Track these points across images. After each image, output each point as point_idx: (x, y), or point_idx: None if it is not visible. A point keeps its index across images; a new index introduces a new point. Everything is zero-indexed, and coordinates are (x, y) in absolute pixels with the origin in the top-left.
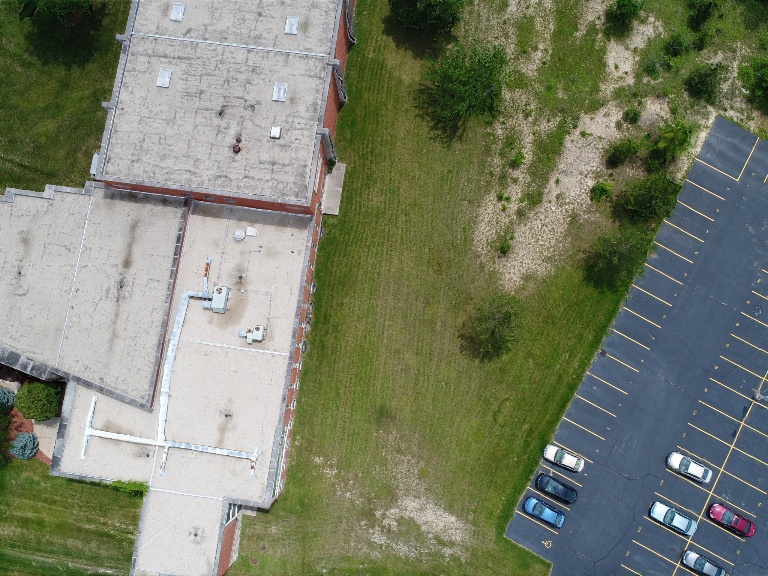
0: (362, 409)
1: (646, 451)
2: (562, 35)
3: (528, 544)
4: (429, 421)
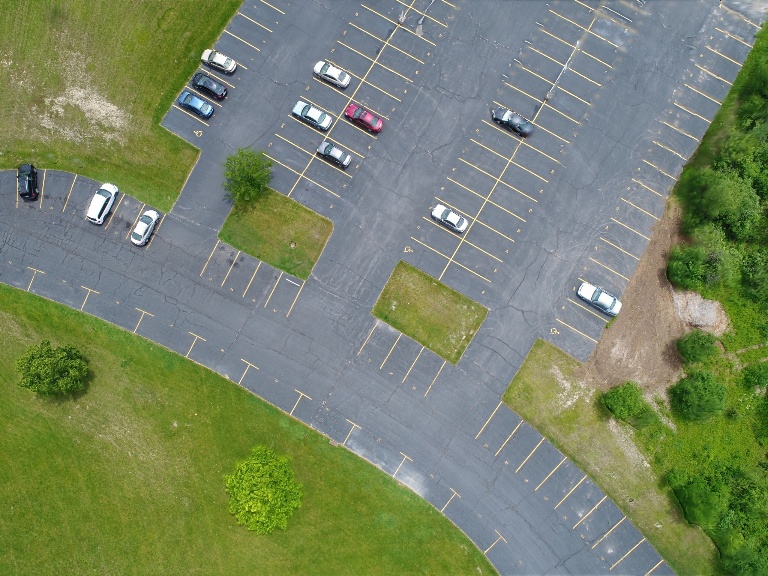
0: (38, 9)
1: (297, 62)
2: None
3: (181, 133)
4: (98, 22)
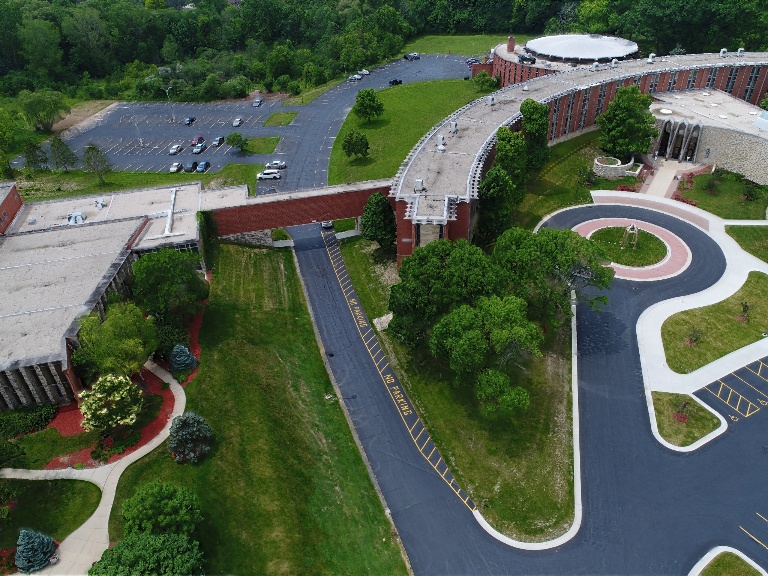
0: None
1: None
2: None
3: None
4: None
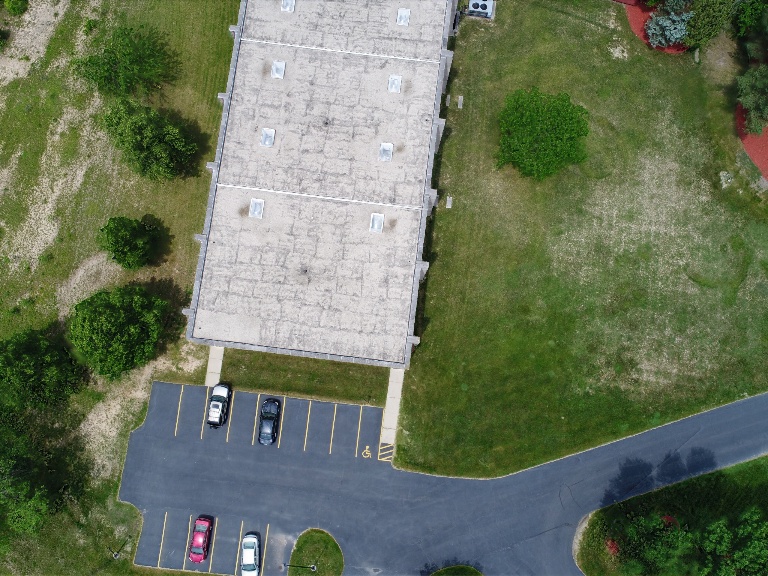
0: None
1: None
2: (35, 150)
3: None
4: None
